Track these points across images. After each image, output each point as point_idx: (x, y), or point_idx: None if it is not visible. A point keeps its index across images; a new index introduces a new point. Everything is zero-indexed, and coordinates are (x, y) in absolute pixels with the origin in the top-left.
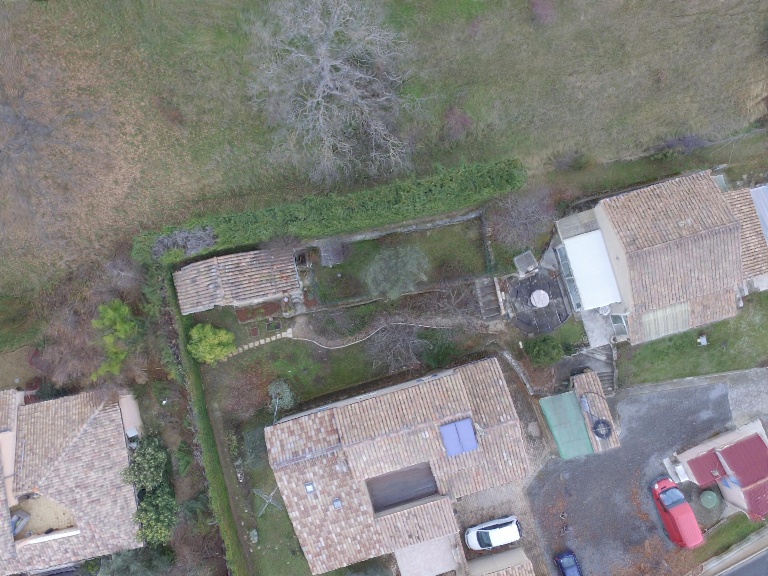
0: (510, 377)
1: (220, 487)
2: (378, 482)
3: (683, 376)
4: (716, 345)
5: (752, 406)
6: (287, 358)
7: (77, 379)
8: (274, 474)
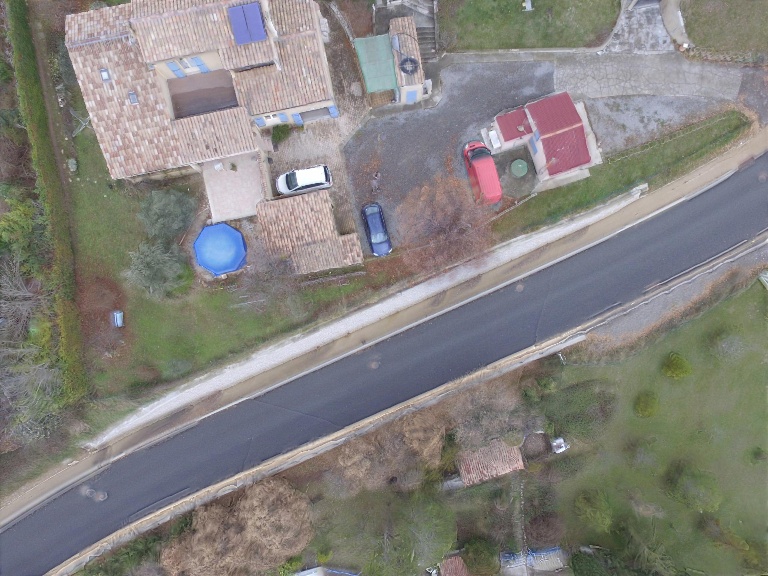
0: (338, 36)
1: (32, 92)
2: (183, 97)
3: (508, 47)
4: (541, 11)
5: (577, 88)
6: None
7: None
8: (69, 54)
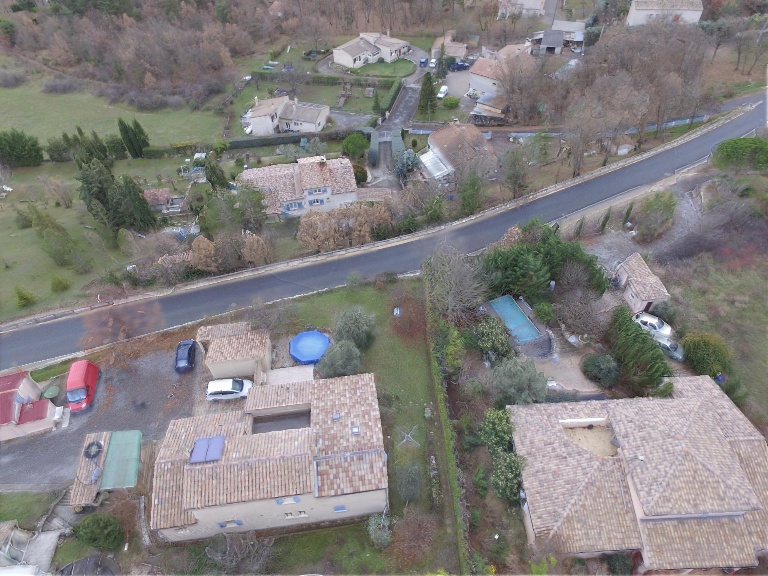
0: None
1: None
2: None
3: (0, 494)
4: None
5: None
6: (368, 571)
7: (588, 574)
8: None
